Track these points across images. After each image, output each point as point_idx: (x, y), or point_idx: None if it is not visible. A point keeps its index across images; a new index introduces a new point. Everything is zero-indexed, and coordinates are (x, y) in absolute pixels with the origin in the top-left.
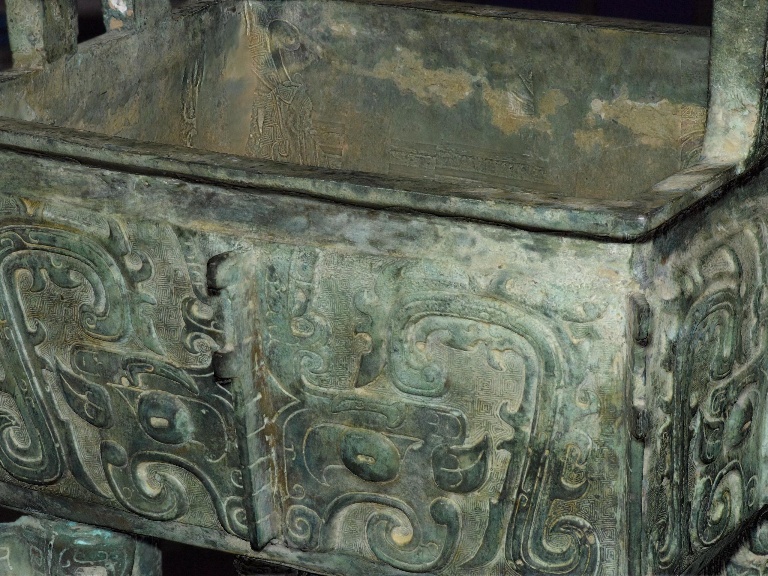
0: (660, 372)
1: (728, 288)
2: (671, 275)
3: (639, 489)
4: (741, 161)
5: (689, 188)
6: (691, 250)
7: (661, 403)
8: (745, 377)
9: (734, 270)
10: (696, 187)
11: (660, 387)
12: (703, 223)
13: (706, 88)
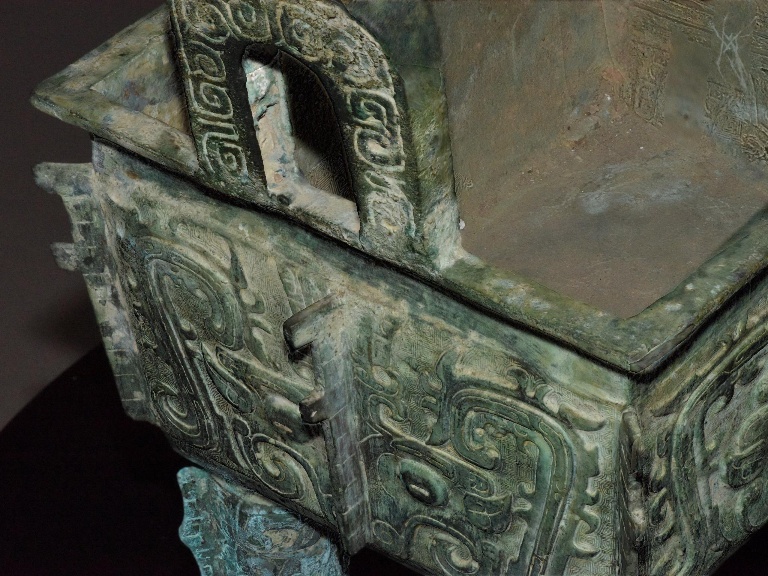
0: None
1: (211, 271)
2: (131, 191)
3: None
4: (196, 169)
5: (110, 126)
6: (185, 204)
7: None
8: None
9: (230, 268)
10: (115, 132)
11: None
12: (226, 206)
13: (762, 269)
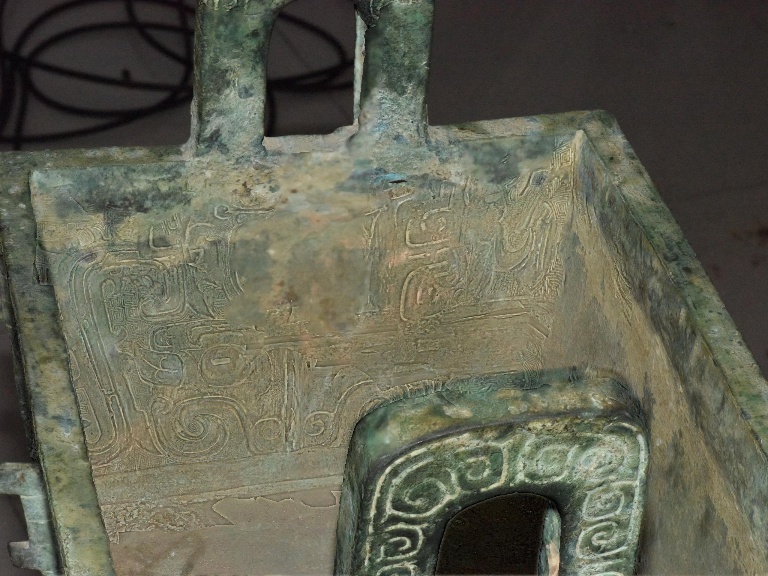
0: None
1: None
2: None
3: None
4: None
5: None
6: None
7: None
8: None
9: None
10: None
11: None
12: None
13: None
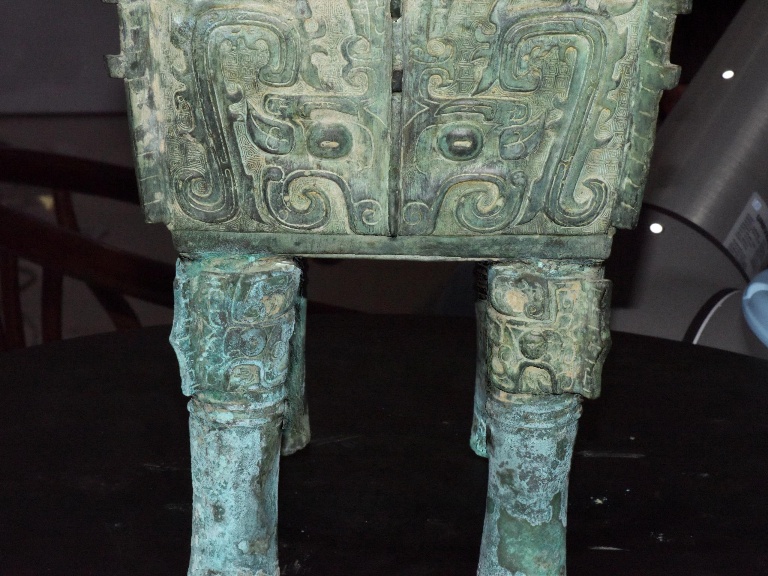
0: (171, 46)
1: (277, 15)
2: None
3: (131, 122)
4: None
5: None
6: None
7: (173, 71)
8: (321, 101)
9: (295, 6)
10: None
11: (174, 58)
12: None
13: None
